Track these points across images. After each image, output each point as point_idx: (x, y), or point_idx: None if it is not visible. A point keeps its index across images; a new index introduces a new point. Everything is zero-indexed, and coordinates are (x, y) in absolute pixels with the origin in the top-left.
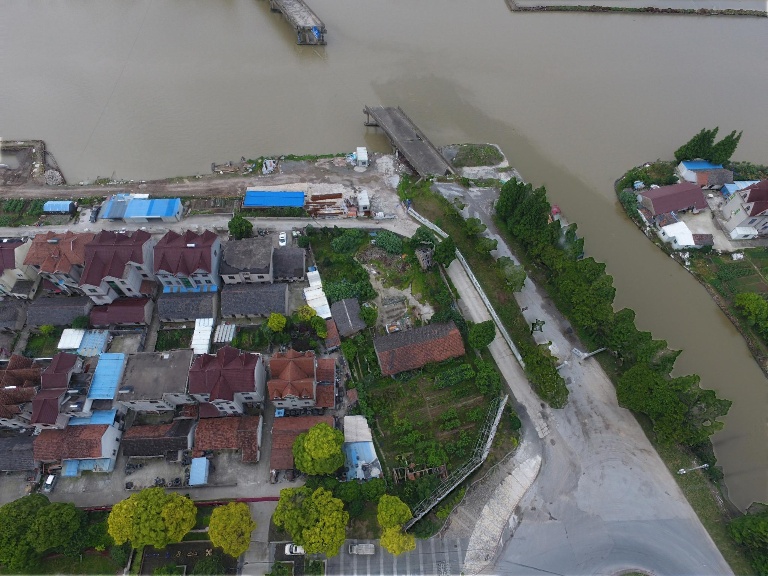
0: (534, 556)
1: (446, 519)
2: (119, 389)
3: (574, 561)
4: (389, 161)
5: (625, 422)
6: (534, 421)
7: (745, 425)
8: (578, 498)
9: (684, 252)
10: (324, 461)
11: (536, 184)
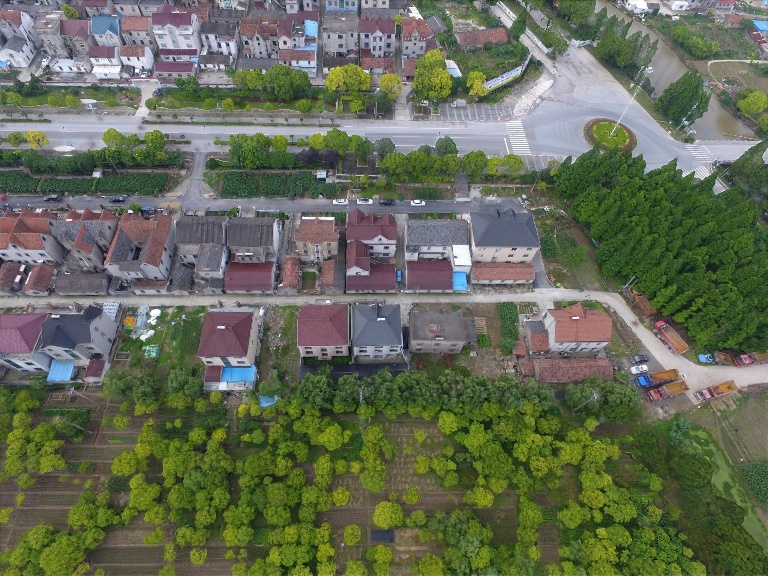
0: (550, 112)
1: (502, 99)
2: (322, 28)
3: (572, 114)
4: None
5: (601, 71)
6: (549, 68)
7: None
8: (574, 95)
9: (641, 14)
10: (437, 60)
11: None
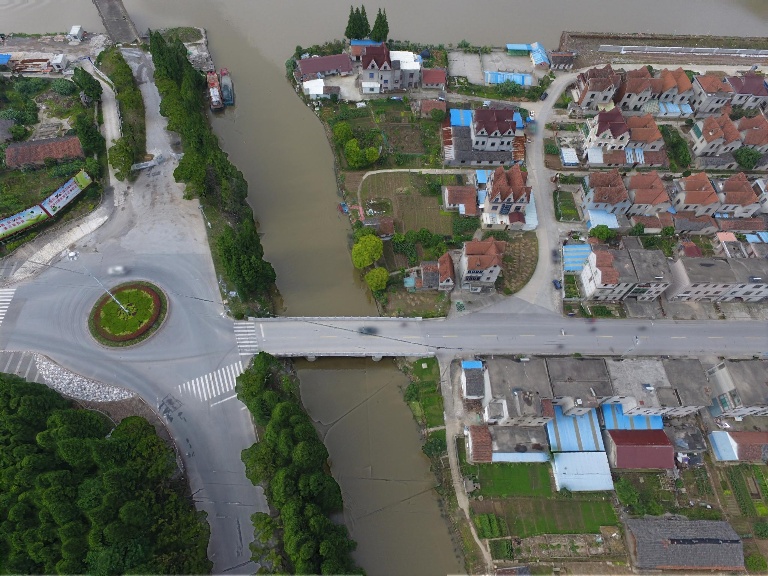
0: (69, 272)
1: (14, 250)
2: None
3: (98, 275)
4: (102, 38)
5: None
6: (116, 196)
7: (314, 216)
8: (123, 240)
9: (317, 101)
10: None
11: (225, 58)
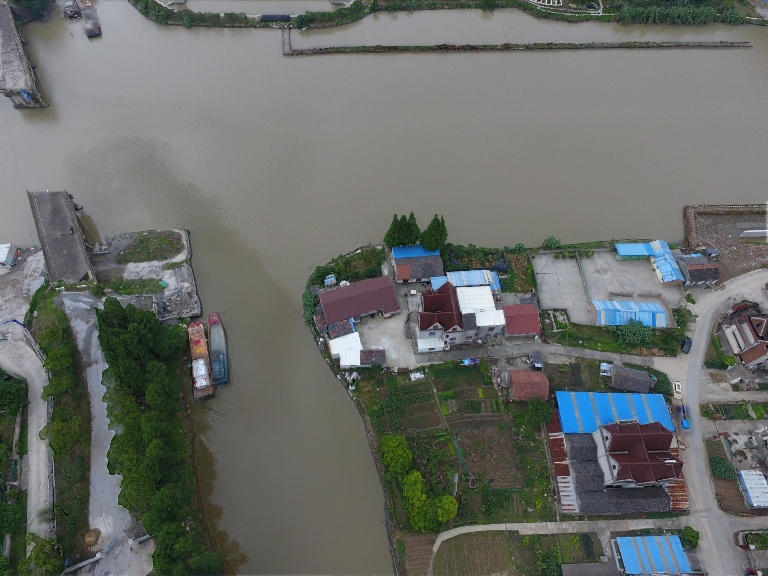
0: None
1: None
2: None
3: None
4: (43, 258)
5: None
6: None
7: None
8: None
9: (351, 372)
10: None
11: (216, 280)
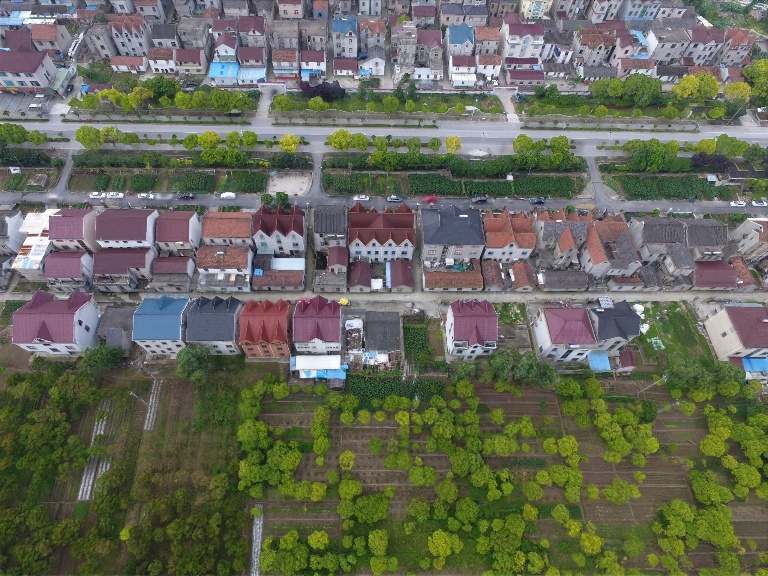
0: None
1: None
2: (657, 38)
3: None
4: None
5: None
6: None
7: None
8: None
9: None
10: None
11: None
